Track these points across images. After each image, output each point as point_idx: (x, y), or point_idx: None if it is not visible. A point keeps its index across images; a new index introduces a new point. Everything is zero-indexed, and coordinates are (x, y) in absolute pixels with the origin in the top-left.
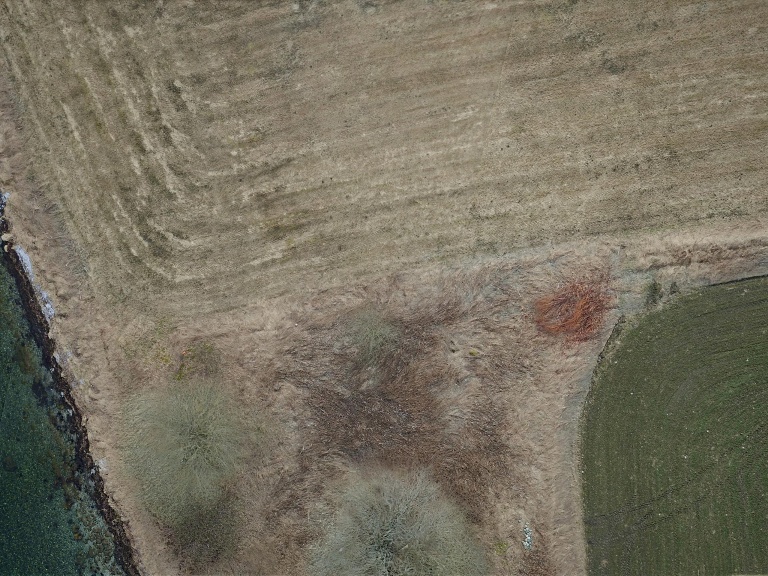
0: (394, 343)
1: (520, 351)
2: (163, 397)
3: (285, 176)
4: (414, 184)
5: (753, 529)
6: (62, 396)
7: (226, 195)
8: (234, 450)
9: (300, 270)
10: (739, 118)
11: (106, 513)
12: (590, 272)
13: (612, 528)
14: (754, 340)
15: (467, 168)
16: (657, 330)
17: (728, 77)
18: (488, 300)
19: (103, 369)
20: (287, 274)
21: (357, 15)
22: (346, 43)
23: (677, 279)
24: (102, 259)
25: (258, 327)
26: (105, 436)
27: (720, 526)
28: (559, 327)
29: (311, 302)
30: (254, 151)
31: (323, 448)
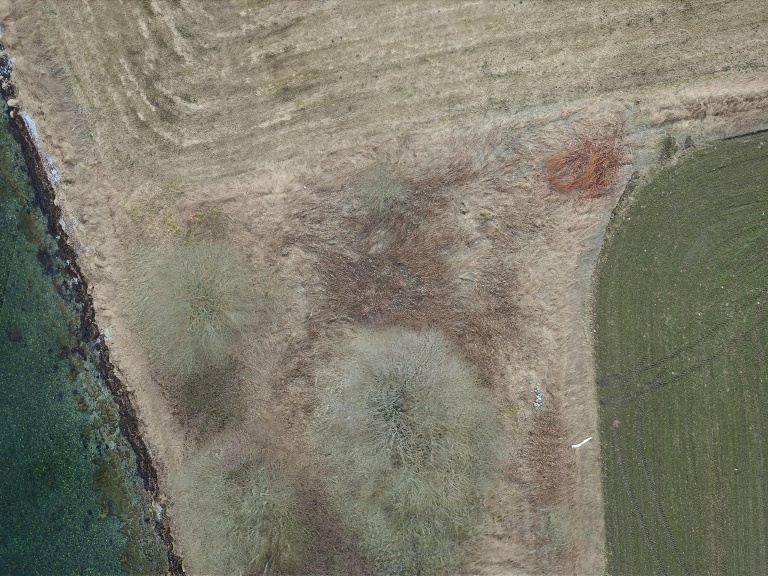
0: (404, 205)
1: (532, 211)
2: (170, 264)
3: (294, 36)
4: (425, 42)
5: (767, 386)
6: (68, 264)
7: (235, 57)
8: (241, 318)
9: (309, 132)
10: None
11: (111, 383)
12: (603, 128)
13: (624, 388)
14: None
15: (479, 25)
16: (671, 185)
17: None
18: (499, 160)
19: (109, 236)
20: (296, 136)
21: None
22: None
23: (692, 133)
24: (109, 124)
25: (266, 190)
26: (111, 304)
27: (734, 383)
28: (572, 184)
29: (320, 164)
30: (263, 11)
31: (331, 314)
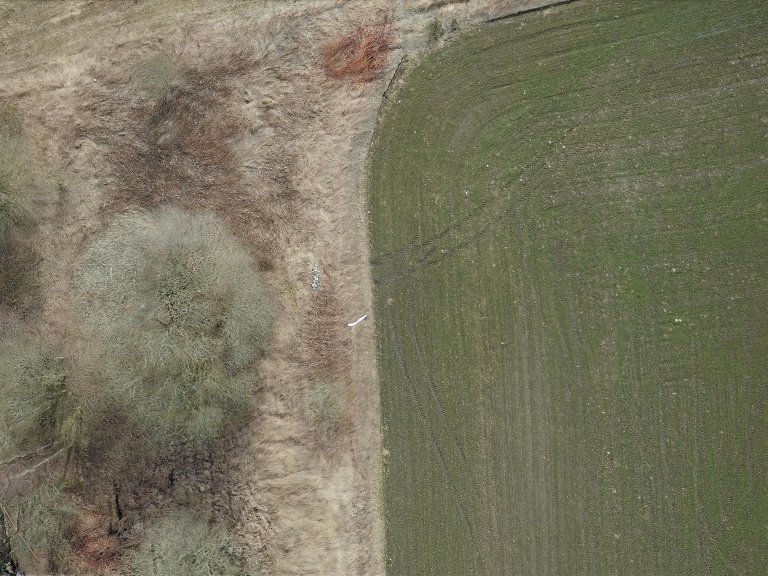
0: (190, 95)
1: (310, 97)
2: None
3: None
4: None
5: (531, 260)
6: None
7: None
8: (39, 211)
9: (98, 25)
10: None
11: None
12: (375, 15)
13: (397, 267)
14: (530, 73)
15: None
16: (439, 68)
17: None
18: (280, 49)
19: None
20: (86, 30)
21: None
22: None
23: (457, 16)
24: None
25: (58, 84)
26: None
27: (500, 259)
28: (344, 68)
29: (109, 56)
30: None
31: (124, 204)
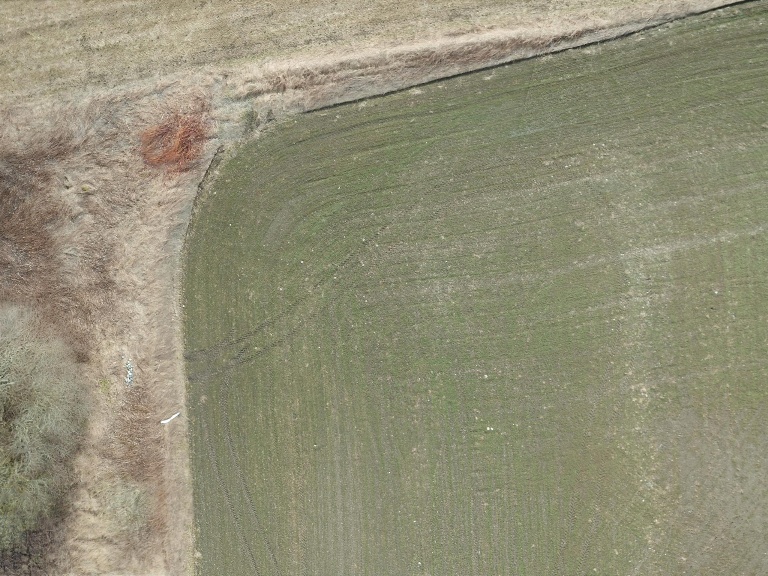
0: (10, 179)
1: (128, 185)
2: None
3: None
4: (26, 15)
5: (344, 361)
6: None
7: None
8: None
9: None
10: None
11: None
12: (193, 102)
13: (211, 363)
14: (345, 167)
15: None
16: (254, 159)
17: None
18: (99, 134)
19: None
20: None
21: None
22: None
23: (273, 106)
24: None
25: None
26: None
27: (313, 359)
28: (160, 158)
29: None
30: None
31: None
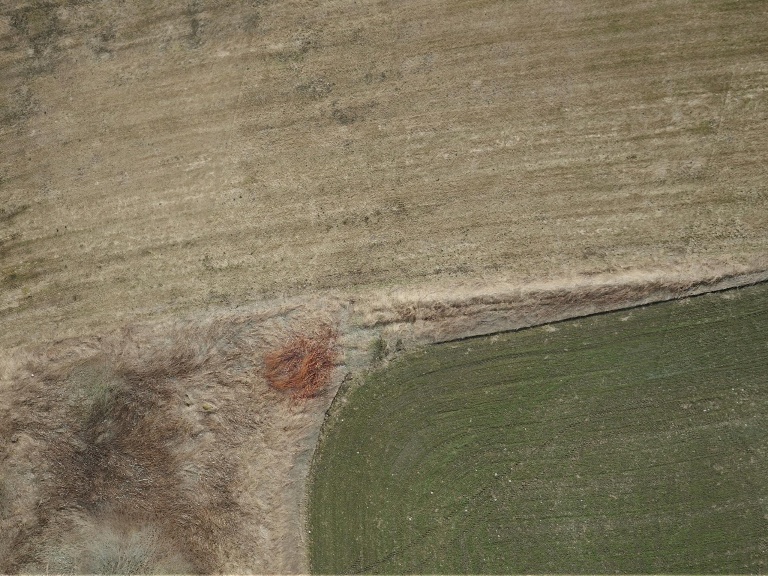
0: (129, 396)
1: (252, 406)
2: None
3: (21, 224)
4: (147, 234)
5: None
6: None
7: None
8: None
9: (36, 320)
10: (465, 172)
11: None
12: (319, 327)
13: None
14: (477, 400)
15: (199, 218)
16: (383, 388)
17: (454, 130)
18: (221, 353)
19: None
20: (24, 323)
21: (91, 61)
22: (80, 89)
23: (402, 336)
24: None
25: None
26: None
27: None
28: (286, 383)
29: (46, 353)
30: None
31: (61, 501)
